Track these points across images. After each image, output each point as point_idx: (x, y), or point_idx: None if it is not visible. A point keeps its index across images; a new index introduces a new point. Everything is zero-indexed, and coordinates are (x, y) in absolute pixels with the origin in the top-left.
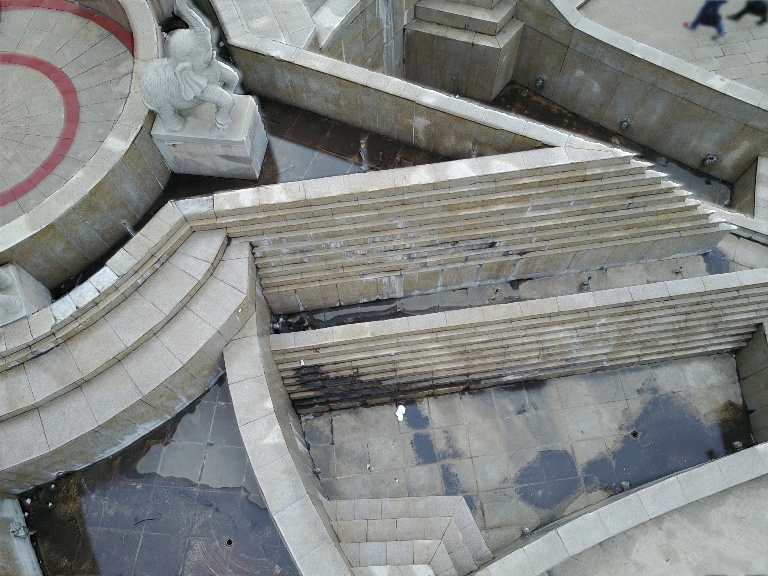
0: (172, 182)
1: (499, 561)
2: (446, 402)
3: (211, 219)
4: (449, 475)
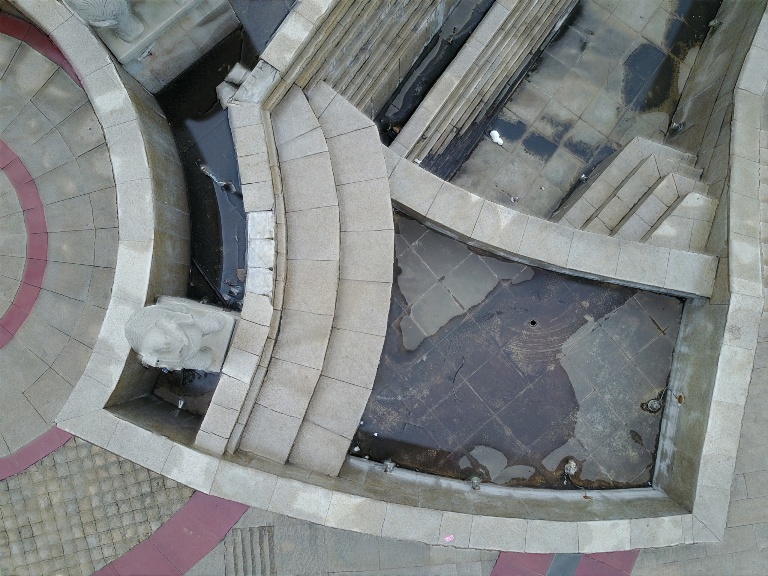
0: (164, 104)
1: (732, 142)
2: (521, 96)
3: (279, 85)
4: (576, 147)
